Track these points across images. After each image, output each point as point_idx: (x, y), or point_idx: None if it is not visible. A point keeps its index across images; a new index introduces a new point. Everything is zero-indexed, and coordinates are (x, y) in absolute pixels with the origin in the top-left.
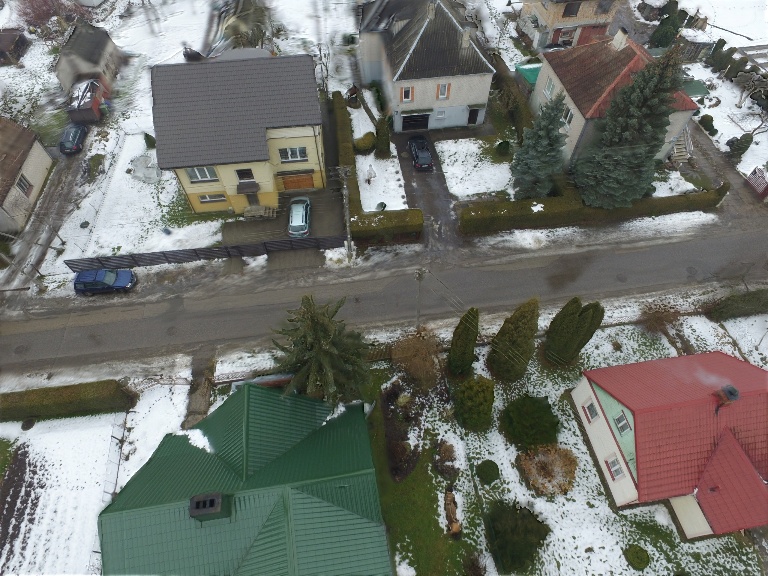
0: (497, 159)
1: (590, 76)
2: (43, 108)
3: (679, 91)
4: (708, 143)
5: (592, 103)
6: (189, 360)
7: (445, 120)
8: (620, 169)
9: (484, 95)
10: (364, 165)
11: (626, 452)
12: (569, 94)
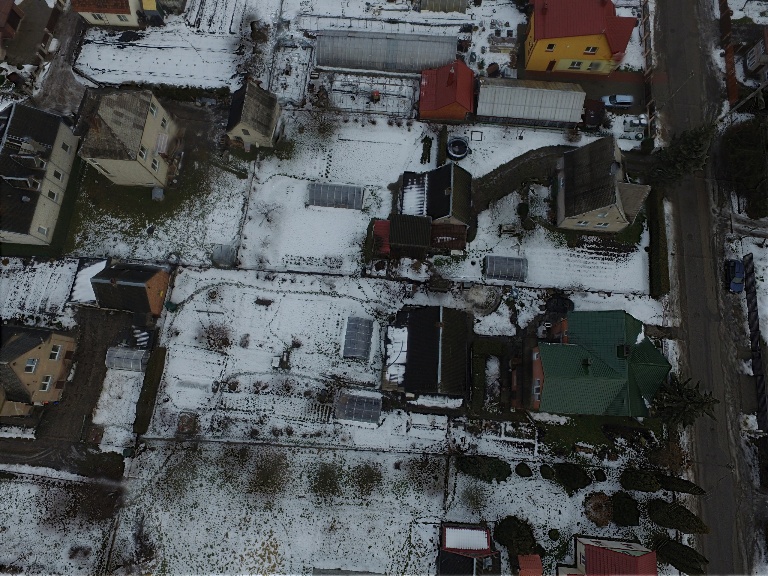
0: None
1: None
2: None
3: None
4: None
5: None
6: (677, 325)
7: None
8: None
9: None
10: None
11: None
12: None
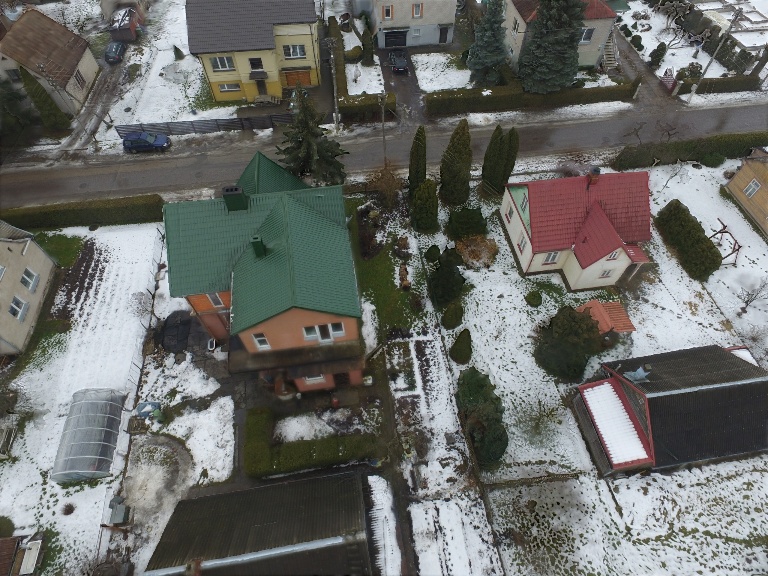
0: (461, 66)
1: None
2: (88, 32)
3: (602, 2)
4: (635, 56)
5: (532, 11)
6: (212, 192)
7: (420, 38)
8: (548, 56)
9: (451, 15)
10: (352, 70)
11: (526, 222)
12: (516, 7)
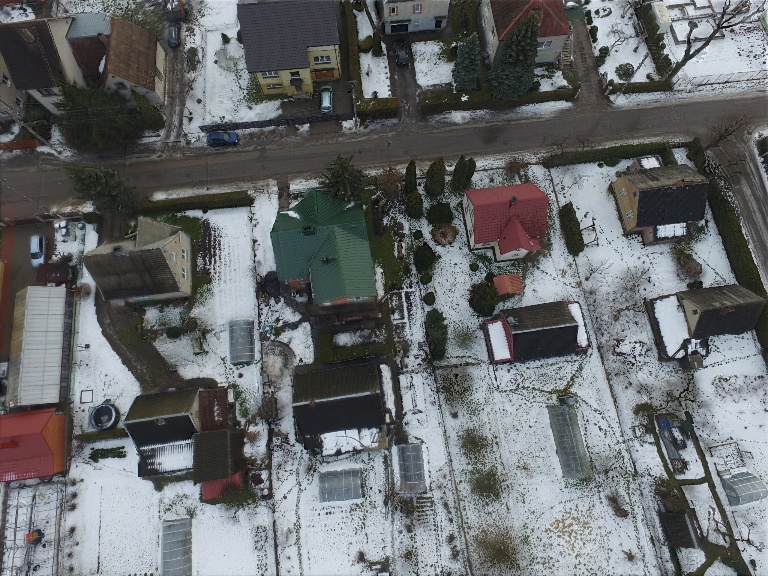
0: (450, 58)
1: (508, 7)
2: (142, 5)
3: (560, 21)
4: (589, 49)
5: (504, 29)
6: (275, 182)
7: (419, 26)
8: None
9: (445, 10)
10: (365, 61)
11: None
12: (494, 19)
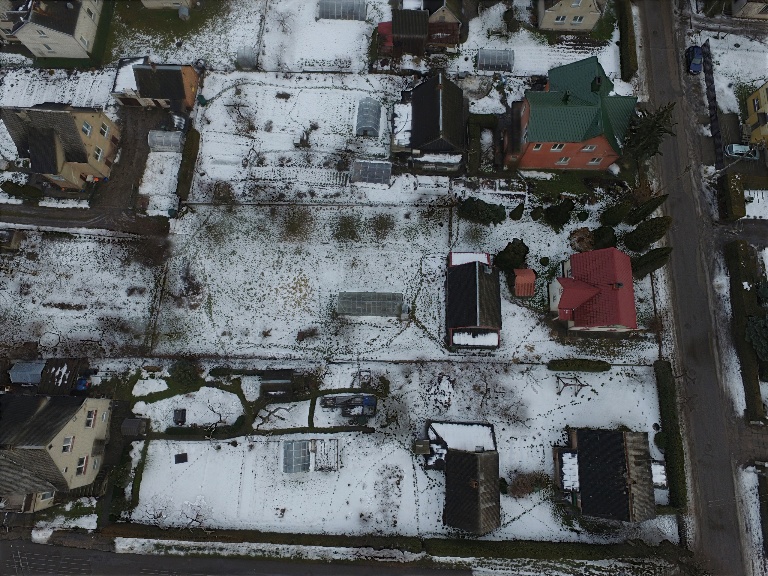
0: None
1: None
2: None
3: None
4: None
5: None
6: (646, 101)
7: None
8: None
9: None
10: None
11: None
12: None
